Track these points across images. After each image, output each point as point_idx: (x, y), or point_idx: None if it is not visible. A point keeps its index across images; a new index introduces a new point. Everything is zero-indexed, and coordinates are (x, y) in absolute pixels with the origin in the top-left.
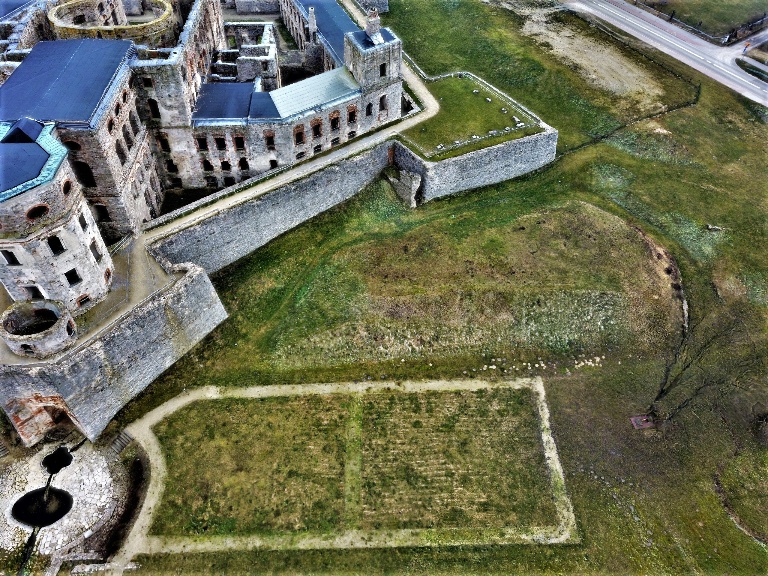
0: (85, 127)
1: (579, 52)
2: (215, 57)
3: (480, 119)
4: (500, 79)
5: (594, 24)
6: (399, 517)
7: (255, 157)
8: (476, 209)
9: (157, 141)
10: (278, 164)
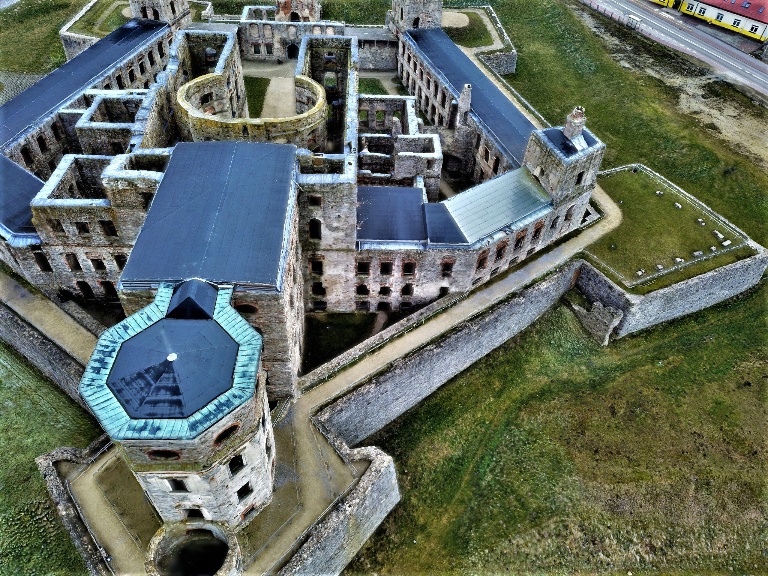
0: (271, 290)
1: (753, 138)
2: (359, 144)
3: (676, 233)
4: (668, 169)
5: (757, 101)
6: None
7: (424, 283)
8: (681, 351)
9: (309, 263)
10: (449, 291)
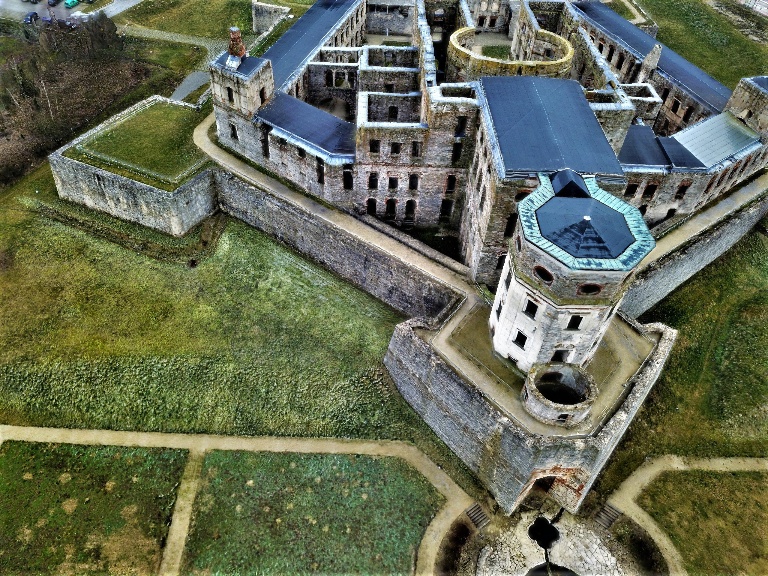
0: (620, 181)
1: None
2: None
3: None
4: None
5: None
6: None
7: (657, 205)
8: None
9: None
10: (676, 213)
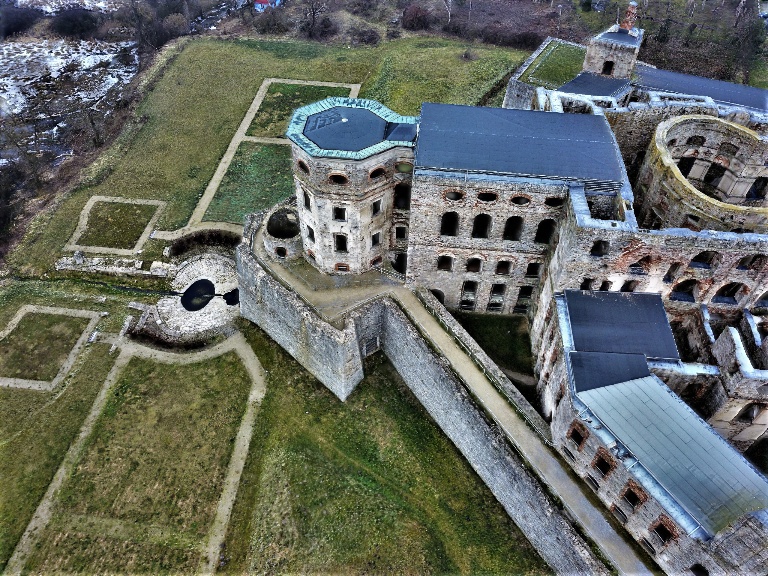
0: None
1: None
2: None
3: None
4: None
5: None
6: (35, 570)
7: None
8: None
9: None
10: None
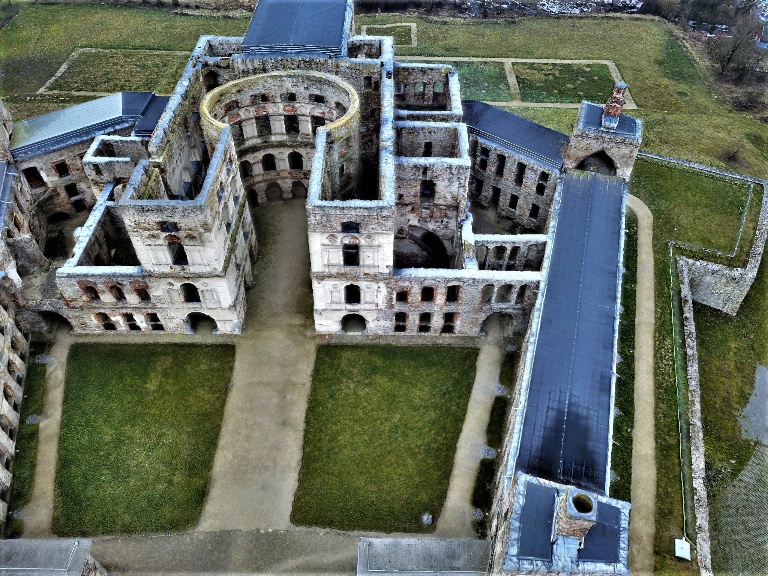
0: None
1: None
2: None
3: None
4: None
5: None
6: None
7: None
8: None
9: None
10: None
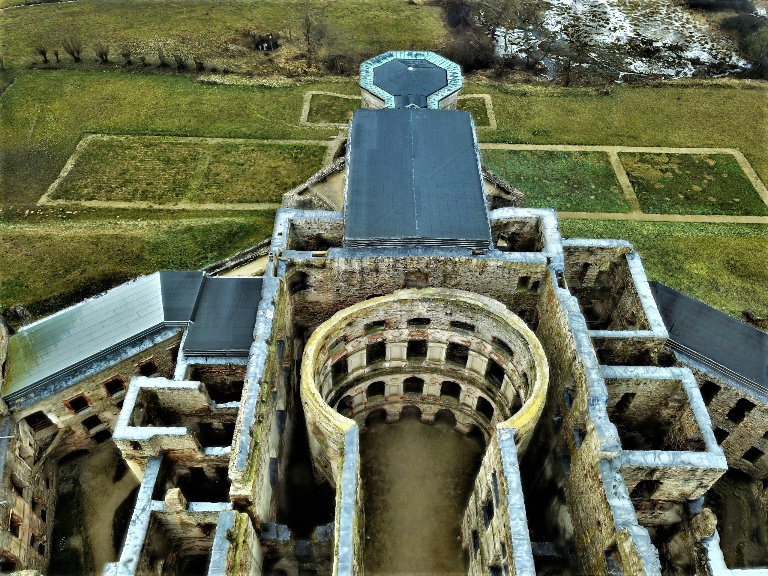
0: None
1: None
2: None
3: None
4: None
5: None
6: (182, 146)
7: None
8: None
9: None
10: None
